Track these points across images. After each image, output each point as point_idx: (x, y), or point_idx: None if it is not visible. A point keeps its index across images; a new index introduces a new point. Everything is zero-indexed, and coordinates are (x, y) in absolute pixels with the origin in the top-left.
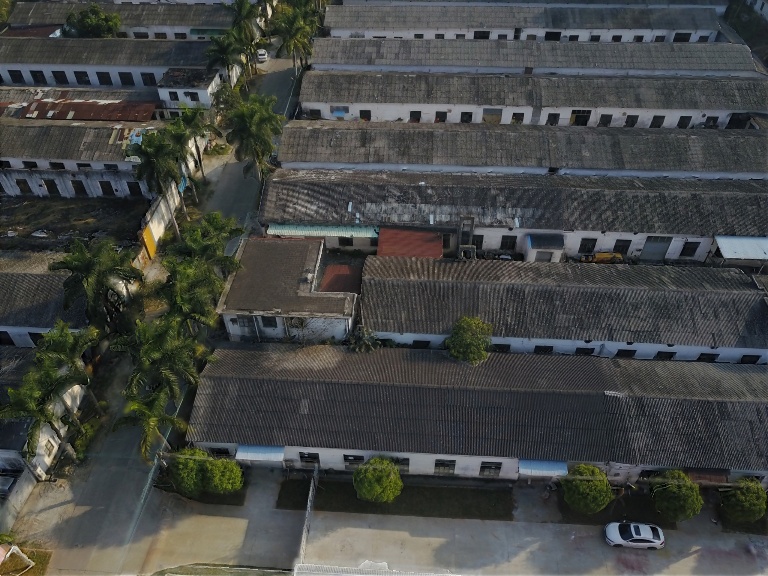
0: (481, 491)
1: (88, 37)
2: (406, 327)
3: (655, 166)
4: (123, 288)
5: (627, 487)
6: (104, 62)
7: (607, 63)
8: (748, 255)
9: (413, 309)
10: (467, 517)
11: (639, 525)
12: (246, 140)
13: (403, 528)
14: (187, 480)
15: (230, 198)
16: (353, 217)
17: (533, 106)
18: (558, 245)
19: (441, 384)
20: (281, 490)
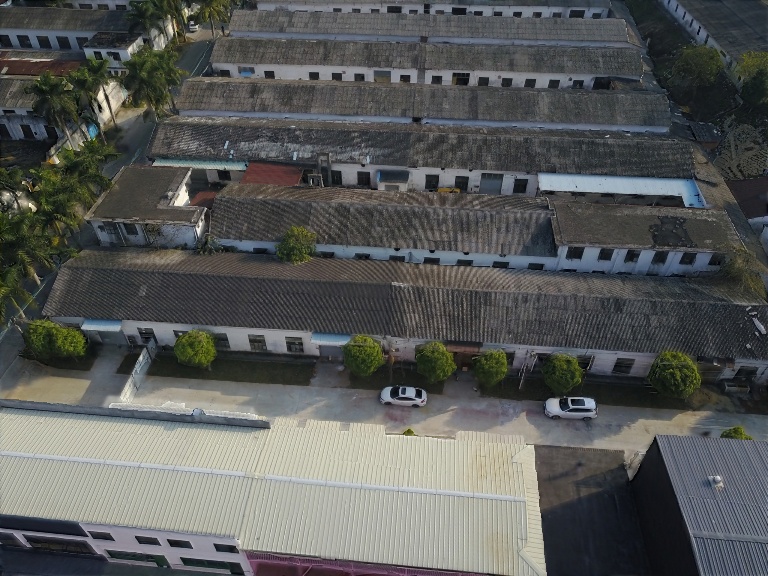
0: (289, 365)
1: (33, 6)
2: (245, 235)
3: (505, 117)
4: (14, 202)
5: (409, 363)
6: (43, 27)
7: (494, 33)
8: (561, 188)
9: (254, 221)
10: (272, 382)
11: (406, 387)
12: (138, 86)
13: (216, 389)
14: (36, 342)
15: (136, 142)
16: (228, 153)
17: (417, 69)
18: (402, 179)
19: (259, 275)
20: (124, 361)
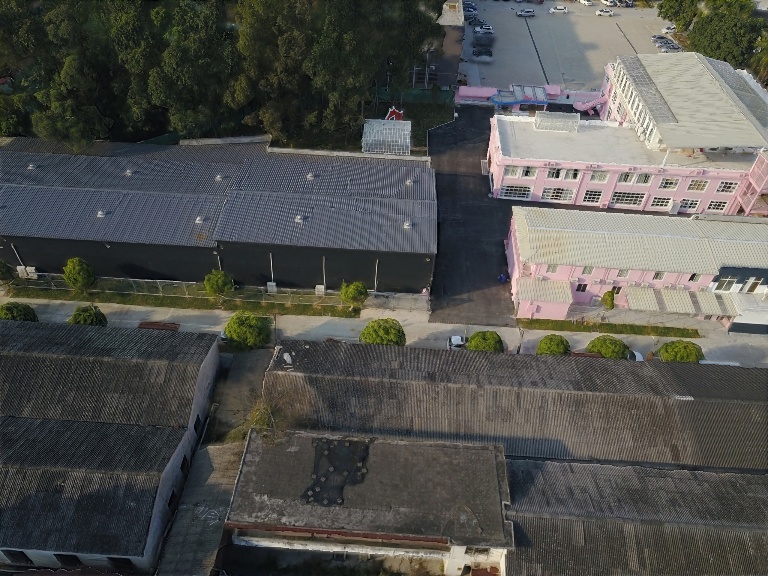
0: None
1: None
2: None
3: None
4: None
5: None
6: None
7: None
8: None
9: None
10: None
11: None
12: None
13: None
14: None
15: None
16: None
17: None
18: None
19: None
20: None
